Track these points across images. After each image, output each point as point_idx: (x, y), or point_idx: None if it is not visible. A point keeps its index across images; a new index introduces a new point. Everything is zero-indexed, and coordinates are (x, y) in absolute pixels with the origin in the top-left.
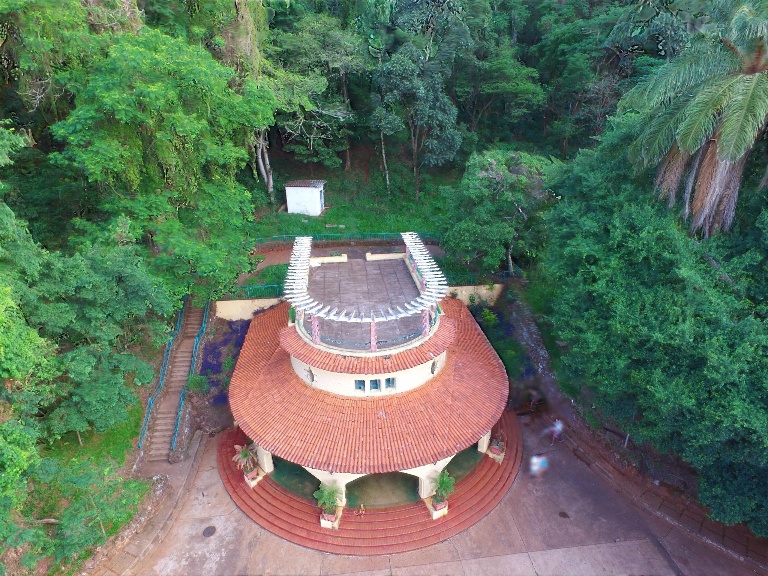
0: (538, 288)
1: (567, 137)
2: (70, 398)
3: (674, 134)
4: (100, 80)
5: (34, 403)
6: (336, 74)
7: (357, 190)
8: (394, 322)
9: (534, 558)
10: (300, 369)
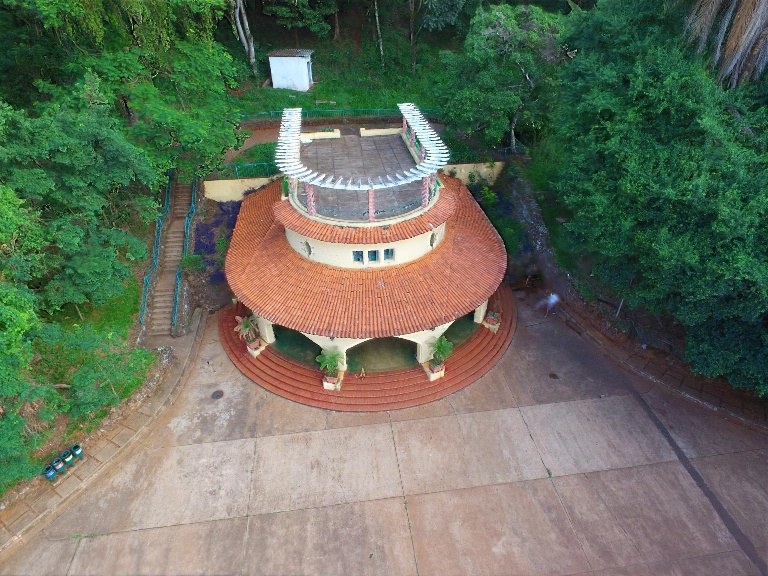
0: (541, 165)
1: None
2: (63, 271)
3: None
4: None
5: (25, 270)
6: None
7: (348, 62)
8: (392, 195)
9: (524, 412)
10: (296, 243)
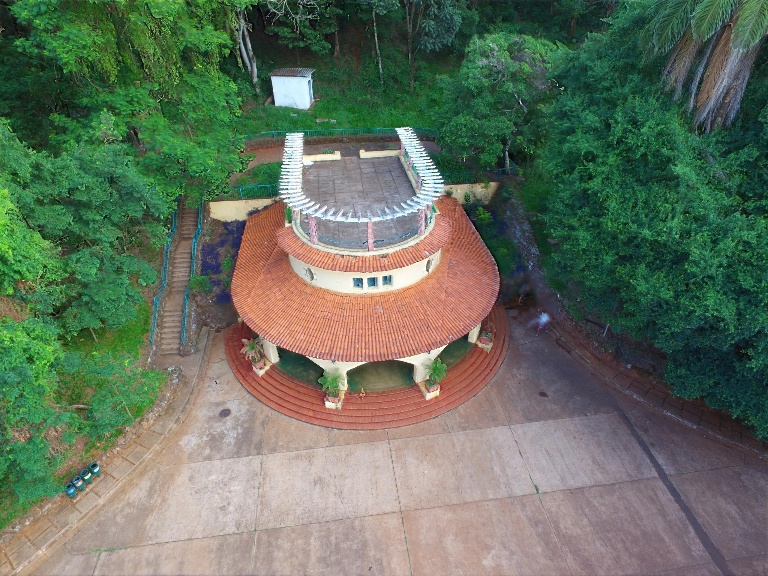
0: (533, 186)
1: (576, 16)
2: (80, 298)
3: (690, 17)
4: None
5: (48, 303)
6: None
7: (348, 80)
8: (390, 222)
9: (514, 430)
10: (299, 268)
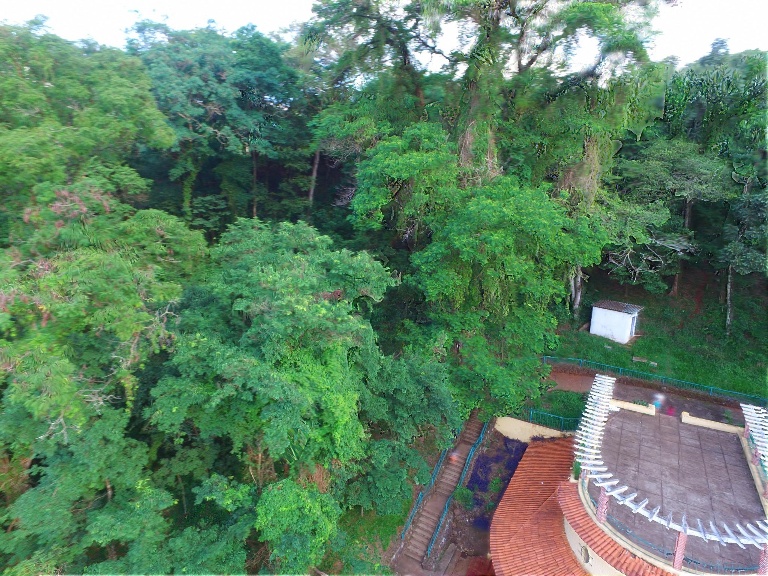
0: None
1: None
2: (366, 476)
3: None
4: (455, 225)
5: (344, 479)
6: (680, 198)
7: (681, 322)
8: None
9: None
10: (574, 539)
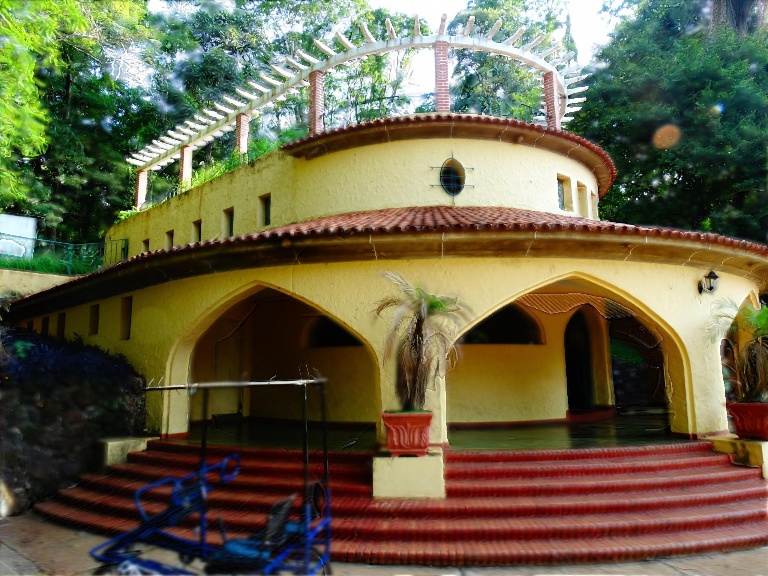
0: None
1: None
2: None
3: None
4: None
5: None
6: (88, 75)
7: None
8: None
9: None
10: (405, 181)
